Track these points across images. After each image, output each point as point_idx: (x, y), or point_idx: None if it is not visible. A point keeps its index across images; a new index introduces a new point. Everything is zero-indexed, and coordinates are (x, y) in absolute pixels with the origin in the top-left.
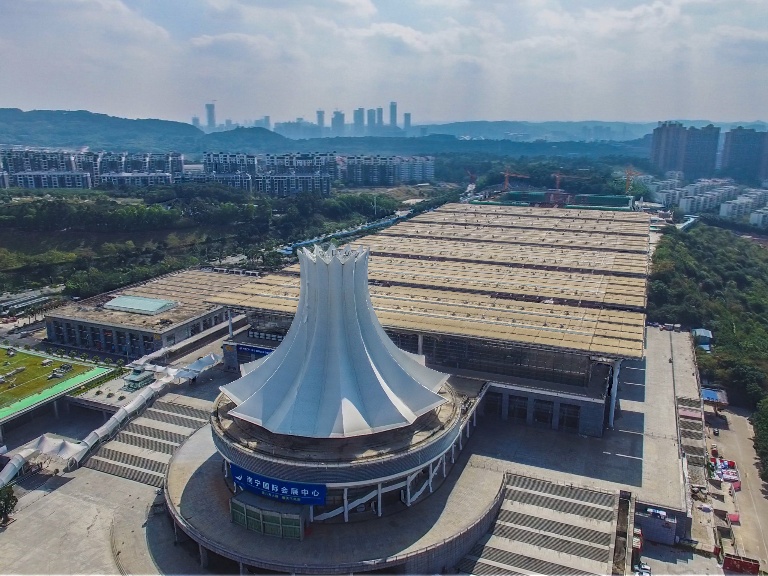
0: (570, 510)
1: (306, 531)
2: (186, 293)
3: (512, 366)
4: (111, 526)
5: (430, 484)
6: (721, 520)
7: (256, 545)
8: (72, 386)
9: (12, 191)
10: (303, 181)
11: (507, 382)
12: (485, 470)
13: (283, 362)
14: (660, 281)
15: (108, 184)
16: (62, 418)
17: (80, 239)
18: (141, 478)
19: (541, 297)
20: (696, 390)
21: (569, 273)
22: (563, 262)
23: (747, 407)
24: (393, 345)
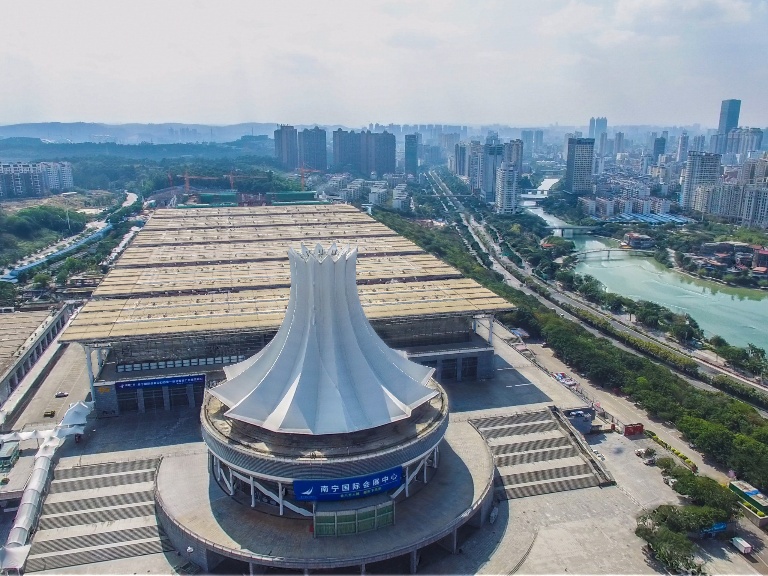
0: (529, 431)
1: None
2: None
3: (412, 338)
4: None
5: None
6: None
7: (363, 544)
8: None
9: None
10: None
11: (416, 352)
12: (453, 424)
13: (303, 368)
14: None
15: None
16: None
17: None
18: (126, 553)
19: (383, 279)
20: (508, 331)
21: None
22: None
23: (531, 337)
24: None
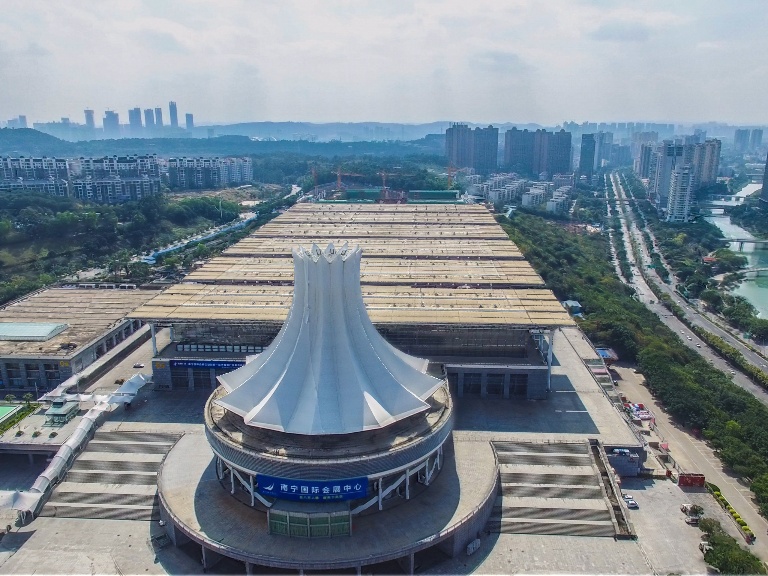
0: (556, 463)
1: None
2: (66, 314)
3: (460, 347)
4: (117, 570)
5: (438, 462)
6: (656, 450)
7: (309, 549)
8: None
9: None
10: (130, 186)
11: (460, 362)
12: (472, 442)
13: (290, 365)
14: None
15: None
16: None
17: None
18: (120, 515)
19: (456, 283)
20: (593, 351)
21: None
22: (449, 251)
23: (626, 360)
24: (381, 337)
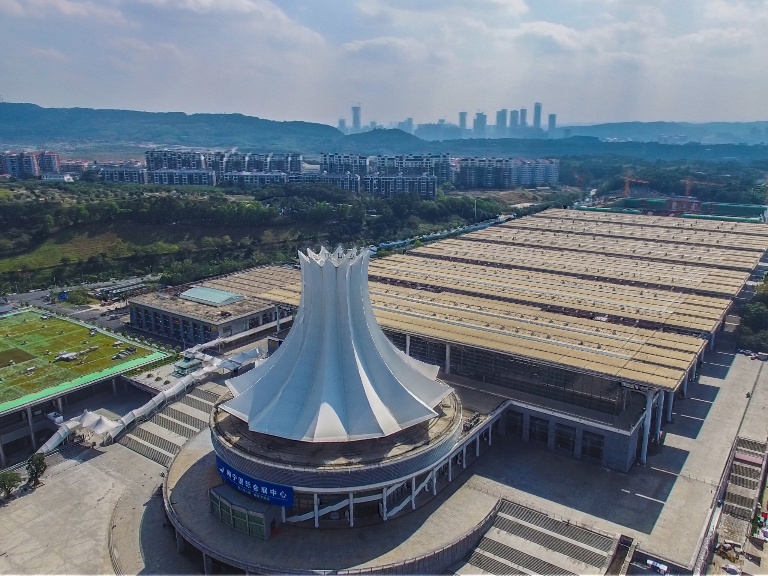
0: (559, 548)
1: (273, 531)
2: (258, 288)
3: (539, 385)
4: (118, 501)
5: (413, 500)
6: None
7: (222, 538)
8: (129, 367)
9: (146, 187)
10: (409, 182)
11: (530, 402)
12: (480, 493)
13: (277, 361)
14: (761, 303)
15: (229, 182)
16: (119, 396)
17: (185, 232)
18: (160, 459)
19: (595, 313)
20: (766, 431)
21: (643, 289)
22: (643, 276)
23: None
24: (394, 353)
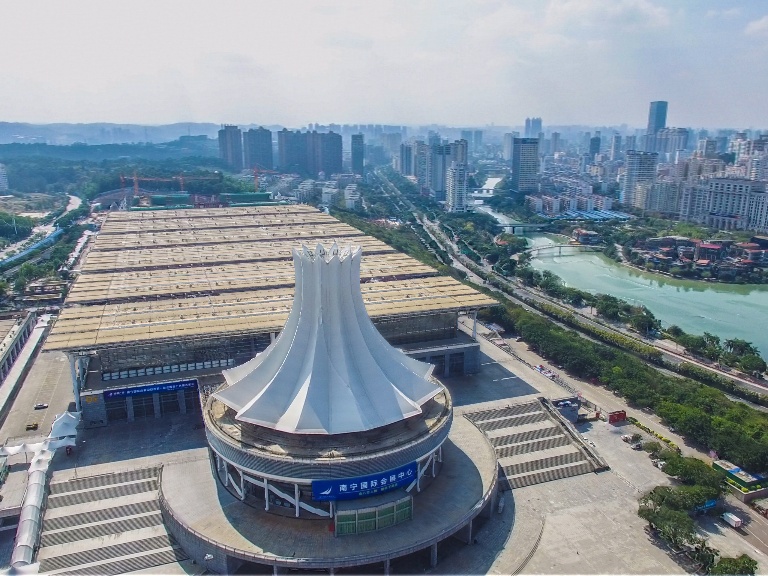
0: (522, 422)
1: None
2: None
3: (400, 336)
4: None
5: None
6: None
7: (385, 540)
8: None
9: None
10: None
11: (404, 350)
12: None
13: (314, 368)
14: None
15: None
16: None
17: None
18: (138, 565)
19: (363, 278)
20: (484, 327)
21: None
22: None
23: (505, 332)
24: None
